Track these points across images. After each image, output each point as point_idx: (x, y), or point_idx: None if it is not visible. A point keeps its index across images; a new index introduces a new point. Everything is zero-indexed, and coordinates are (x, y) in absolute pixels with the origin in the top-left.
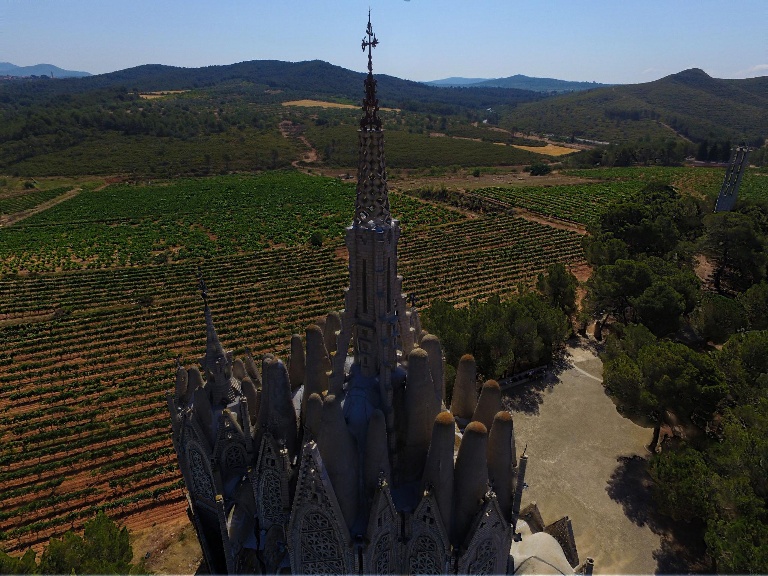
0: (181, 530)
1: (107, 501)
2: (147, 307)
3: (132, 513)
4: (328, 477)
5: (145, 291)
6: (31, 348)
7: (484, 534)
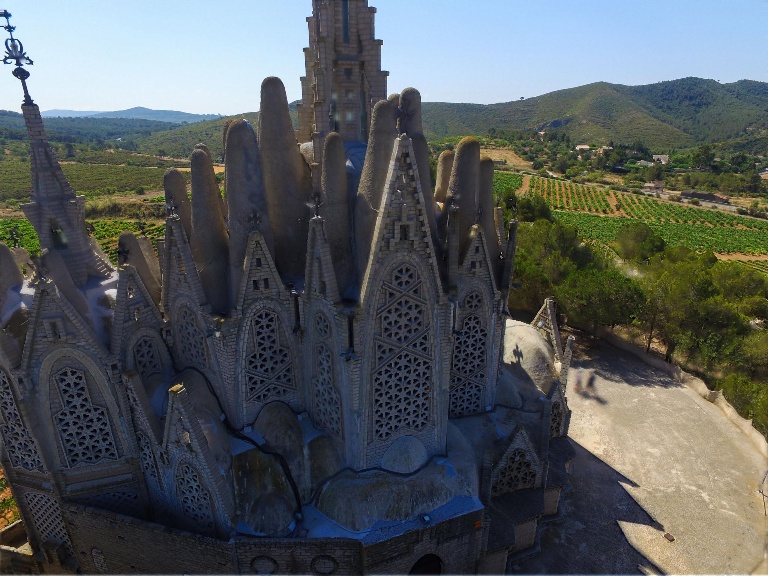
0: None
1: None
2: None
3: None
4: None
5: None
6: None
7: None
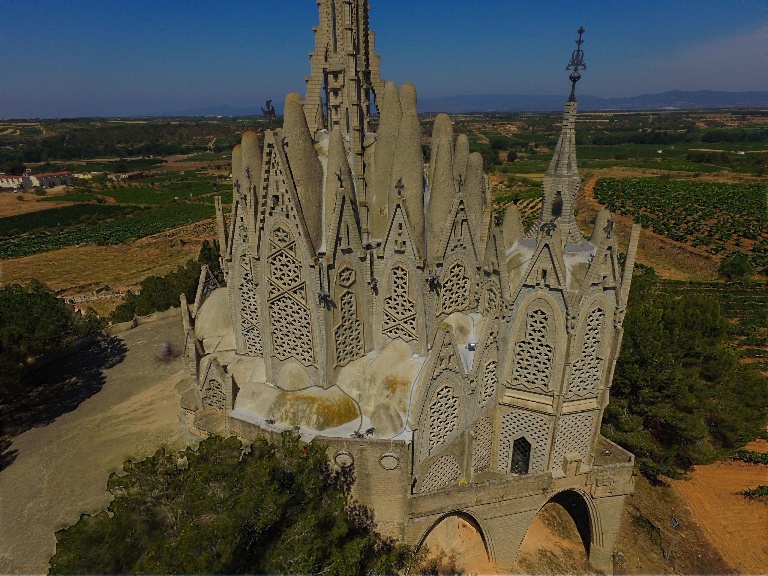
0: None
1: None
2: None
3: None
4: None
5: None
6: None
7: None
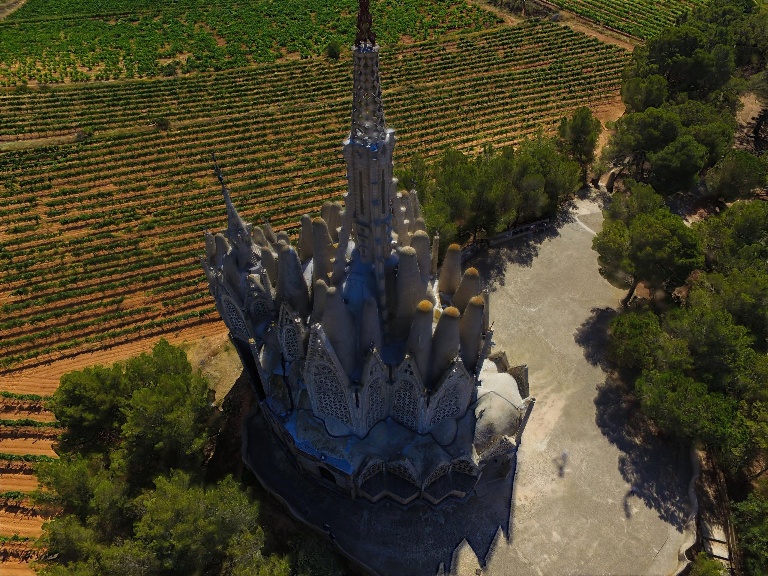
0: (225, 343)
1: (163, 317)
2: (165, 130)
3: (185, 327)
4: (331, 346)
5: (160, 111)
6: (65, 173)
7: (451, 382)
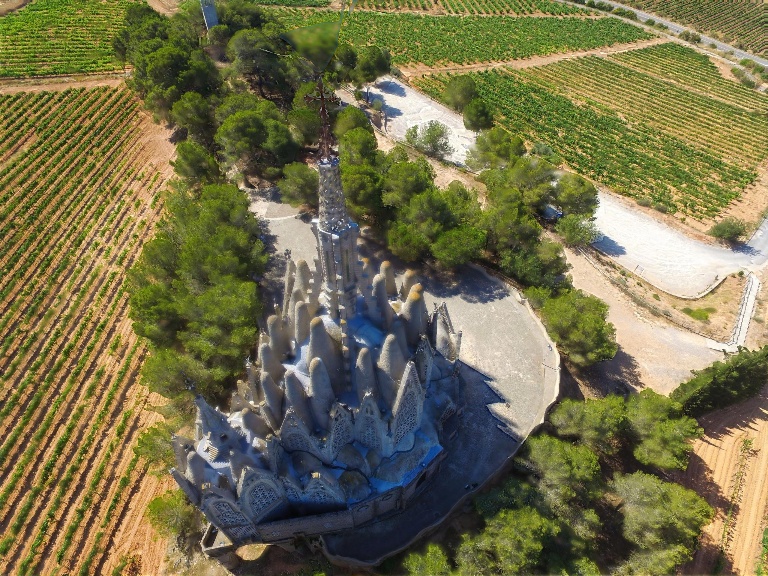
0: None
1: None
2: None
3: None
4: None
5: None
6: None
7: None
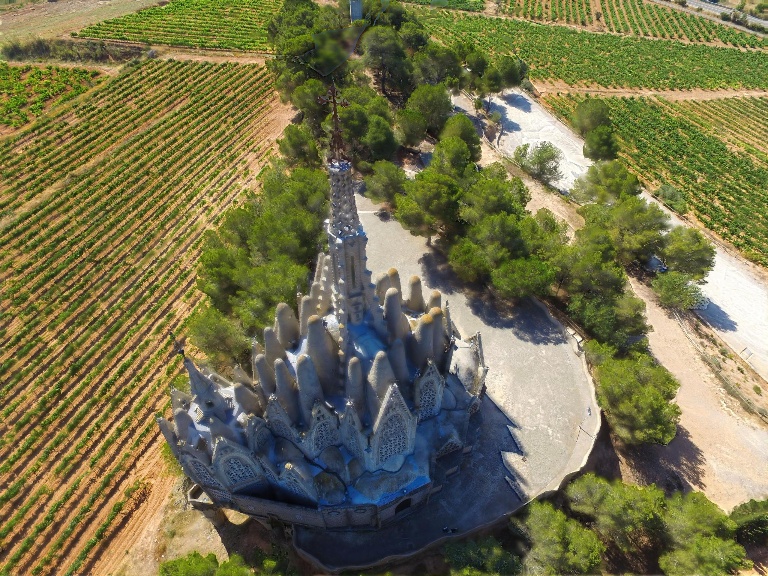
0: (160, 532)
1: None
2: None
3: (91, 567)
4: None
5: None
6: None
7: None
